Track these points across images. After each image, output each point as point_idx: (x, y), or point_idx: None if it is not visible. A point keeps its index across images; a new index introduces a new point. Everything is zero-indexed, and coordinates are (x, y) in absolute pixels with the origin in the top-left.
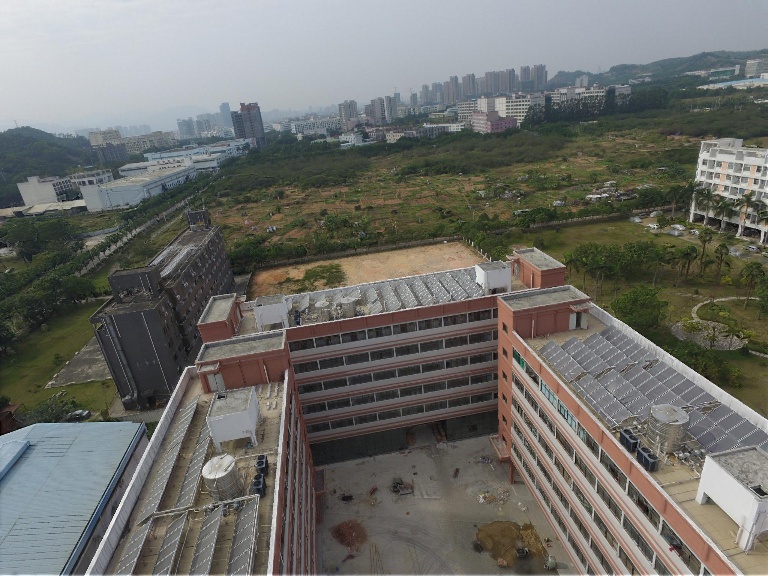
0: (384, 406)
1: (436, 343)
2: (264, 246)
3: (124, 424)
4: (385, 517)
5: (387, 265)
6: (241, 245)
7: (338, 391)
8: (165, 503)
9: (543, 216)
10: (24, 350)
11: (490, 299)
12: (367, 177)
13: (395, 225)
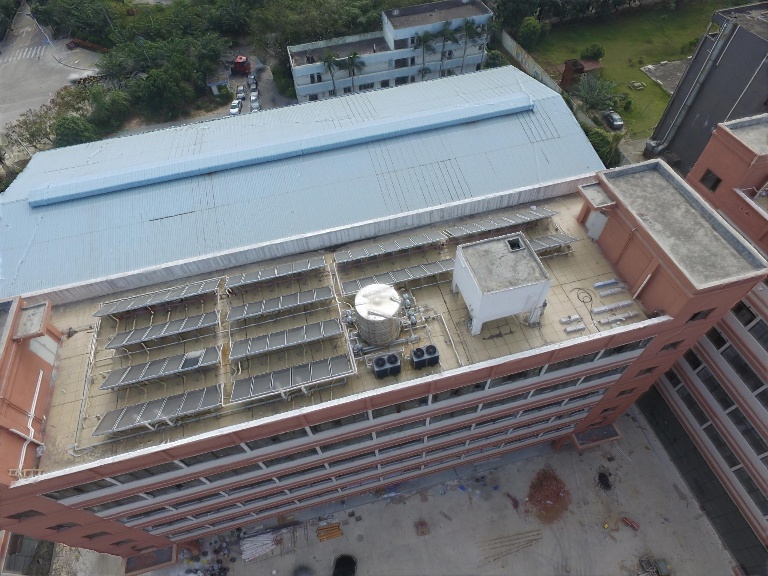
0: None
1: None
2: None
3: (599, 165)
4: (589, 550)
5: None
6: None
7: None
8: (367, 266)
9: None
10: (690, 12)
11: None
12: None
13: None
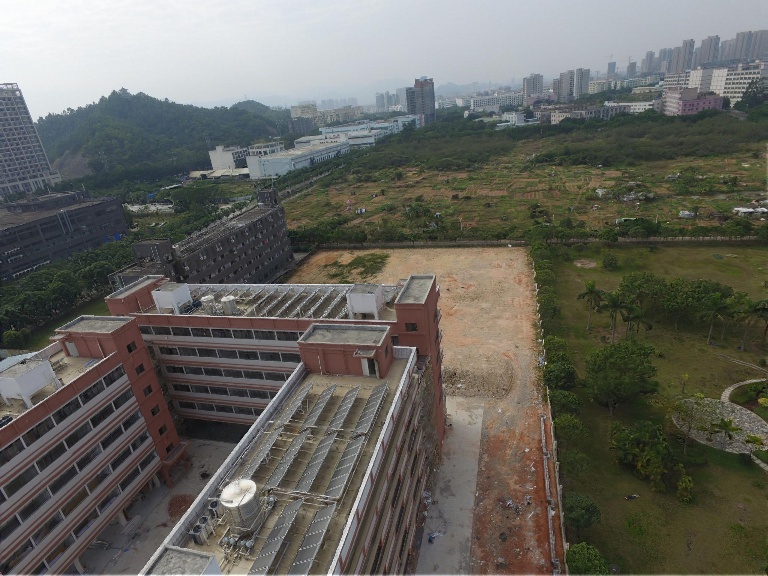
0: (257, 403)
1: (296, 356)
2: (343, 227)
3: None
4: None
5: (430, 263)
6: (322, 224)
7: (216, 379)
8: None
9: (637, 229)
10: None
11: (343, 323)
12: (496, 163)
13: (461, 221)
